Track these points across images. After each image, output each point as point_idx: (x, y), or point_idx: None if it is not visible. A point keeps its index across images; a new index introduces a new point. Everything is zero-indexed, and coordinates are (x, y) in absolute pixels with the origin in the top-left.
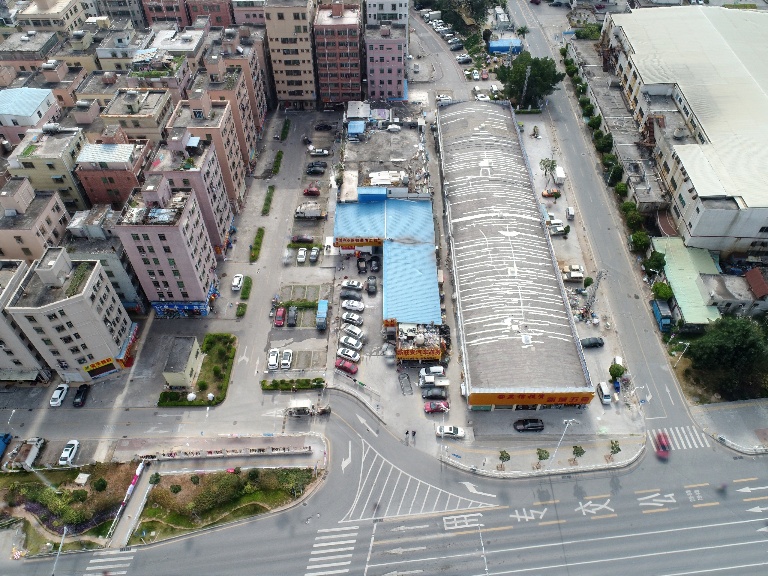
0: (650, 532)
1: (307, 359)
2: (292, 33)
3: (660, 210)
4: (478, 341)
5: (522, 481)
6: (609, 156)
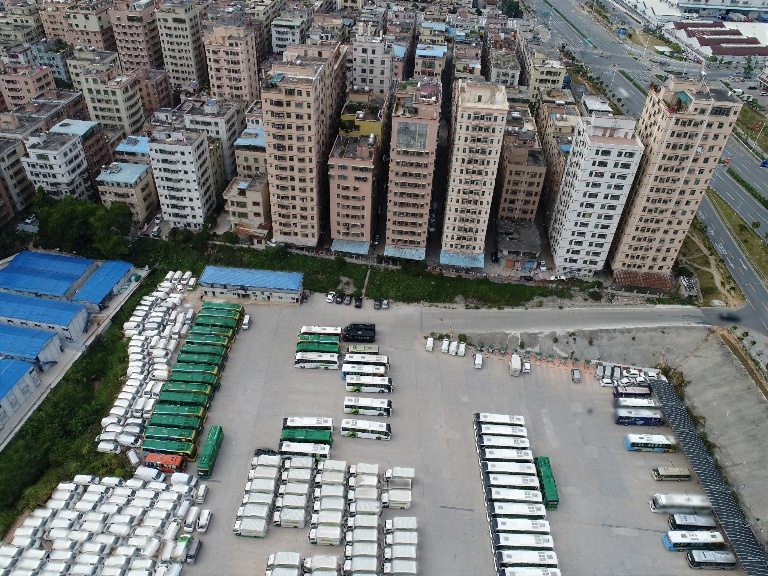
0: None
1: None
2: (363, 2)
3: (453, 8)
4: None
5: None
6: (425, 6)
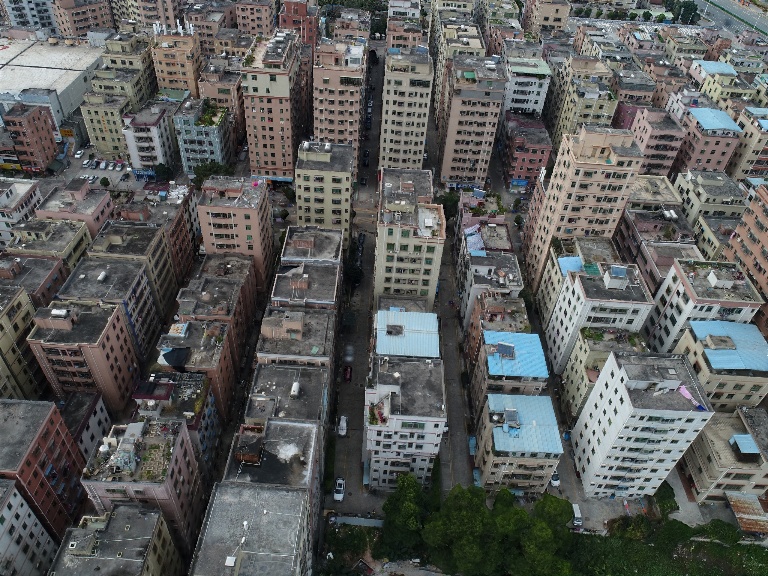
0: None
1: None
2: None
3: None
4: None
5: None
6: (582, 8)
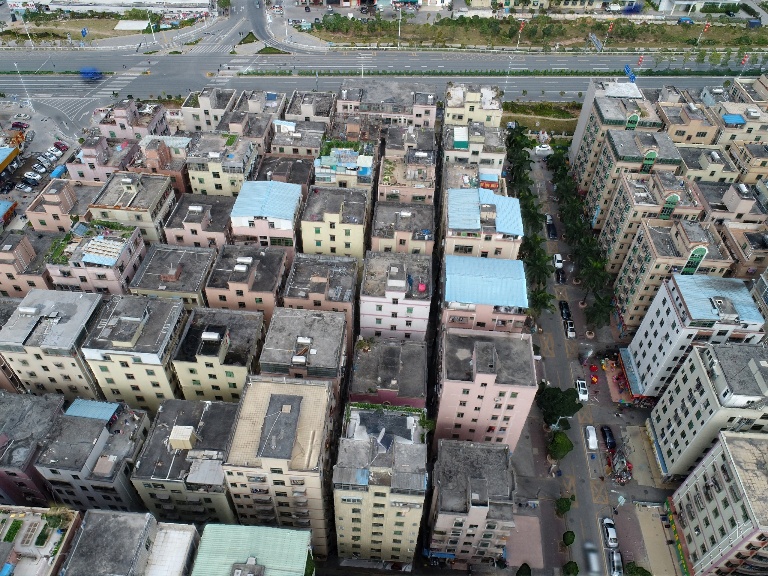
0: None
1: None
2: None
3: None
4: None
5: (2, 103)
6: None
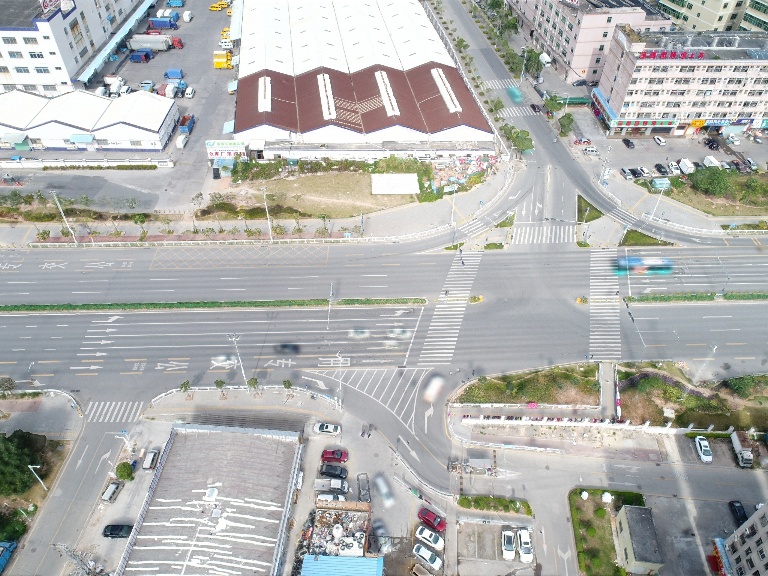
0: (194, 346)
1: (483, 545)
2: None
3: None
4: (269, 506)
5: None
6: None
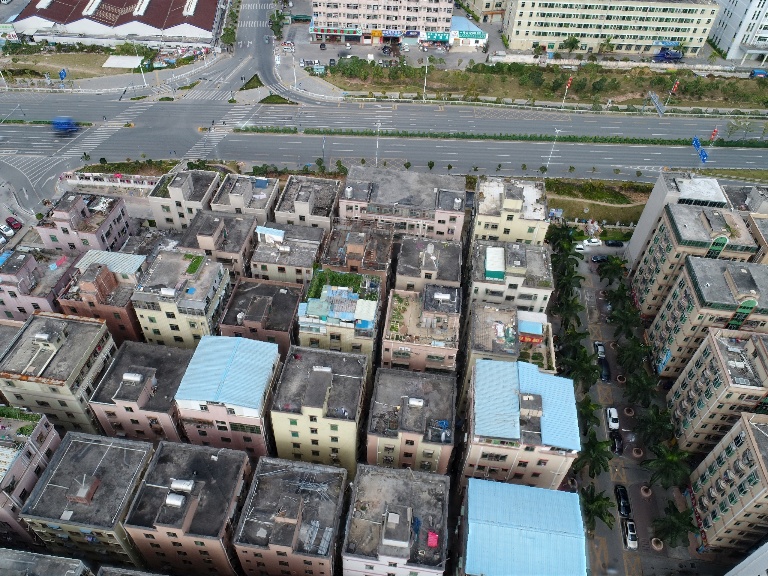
0: None
1: None
2: None
3: None
4: None
5: None
6: None
